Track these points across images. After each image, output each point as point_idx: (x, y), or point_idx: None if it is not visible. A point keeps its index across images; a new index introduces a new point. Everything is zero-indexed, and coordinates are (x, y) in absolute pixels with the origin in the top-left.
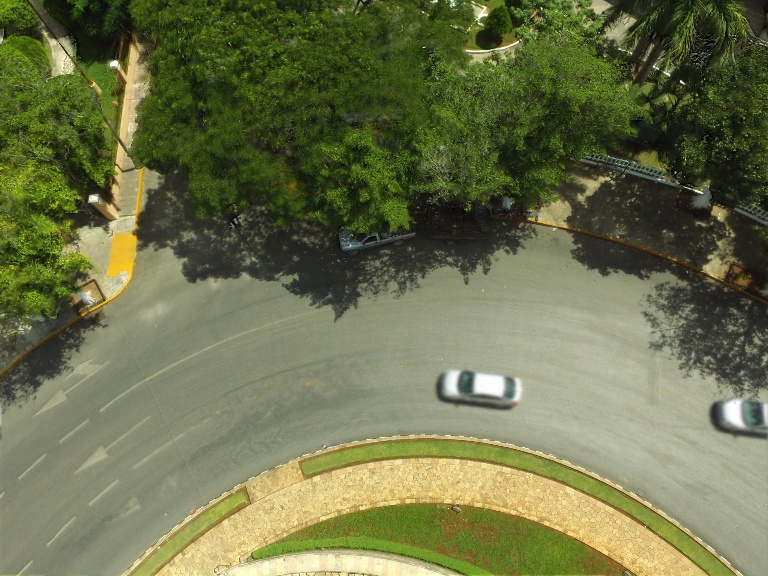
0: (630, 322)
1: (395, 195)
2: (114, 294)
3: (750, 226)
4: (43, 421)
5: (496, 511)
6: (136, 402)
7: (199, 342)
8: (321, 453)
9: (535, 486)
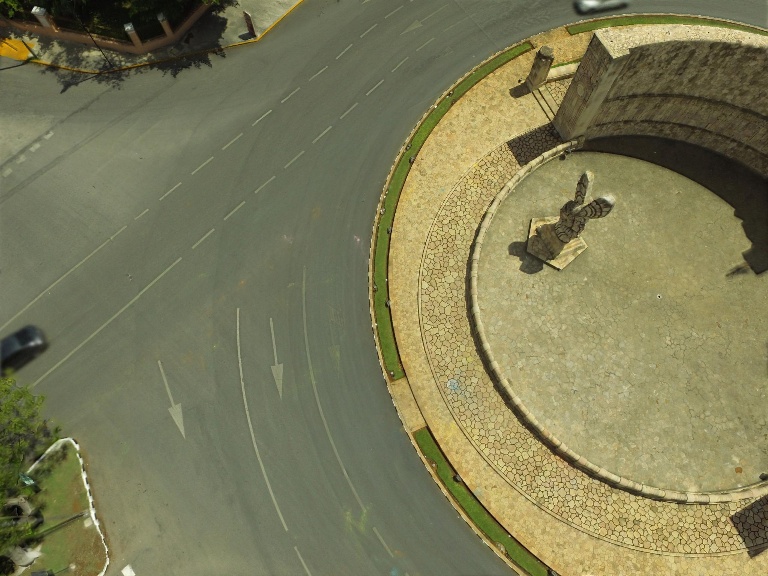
0: None
1: None
2: None
3: None
4: (369, 7)
5: None
6: None
7: None
8: (581, 23)
9: None
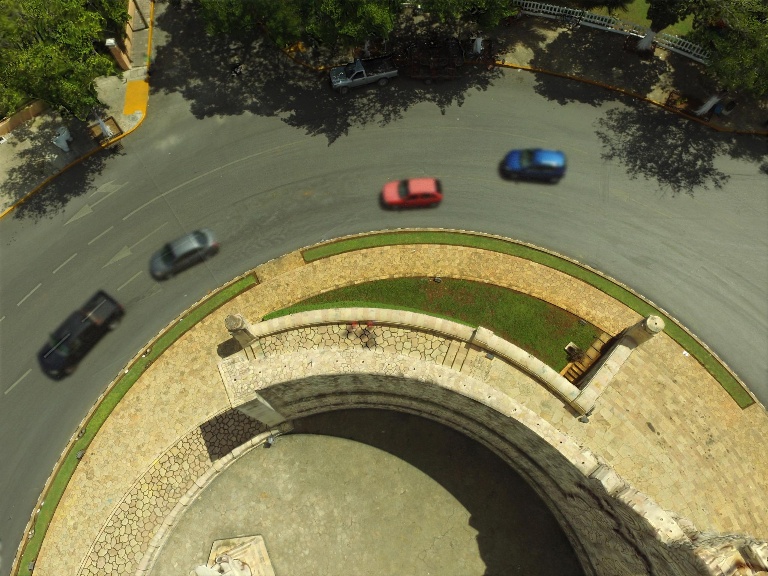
0: (585, 139)
1: (379, 8)
2: (130, 129)
3: (687, 63)
4: (72, 229)
5: (471, 281)
6: (155, 212)
7: (209, 165)
8: (320, 245)
9: (504, 261)
